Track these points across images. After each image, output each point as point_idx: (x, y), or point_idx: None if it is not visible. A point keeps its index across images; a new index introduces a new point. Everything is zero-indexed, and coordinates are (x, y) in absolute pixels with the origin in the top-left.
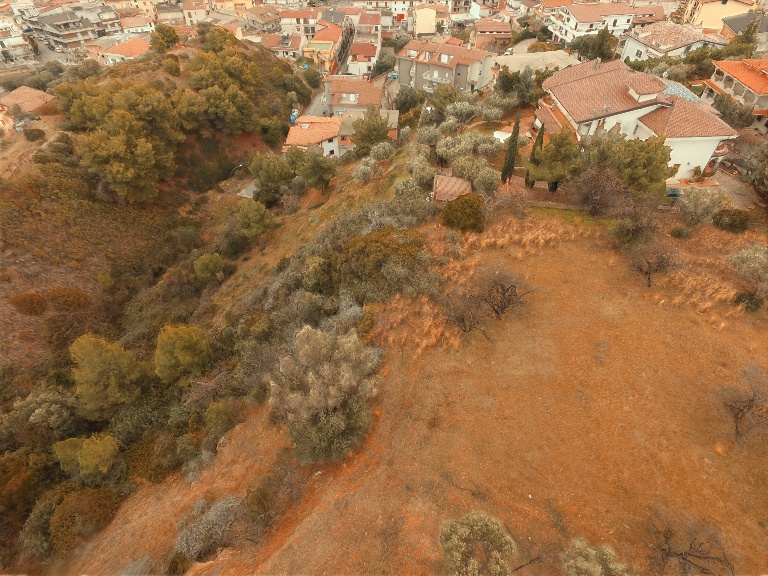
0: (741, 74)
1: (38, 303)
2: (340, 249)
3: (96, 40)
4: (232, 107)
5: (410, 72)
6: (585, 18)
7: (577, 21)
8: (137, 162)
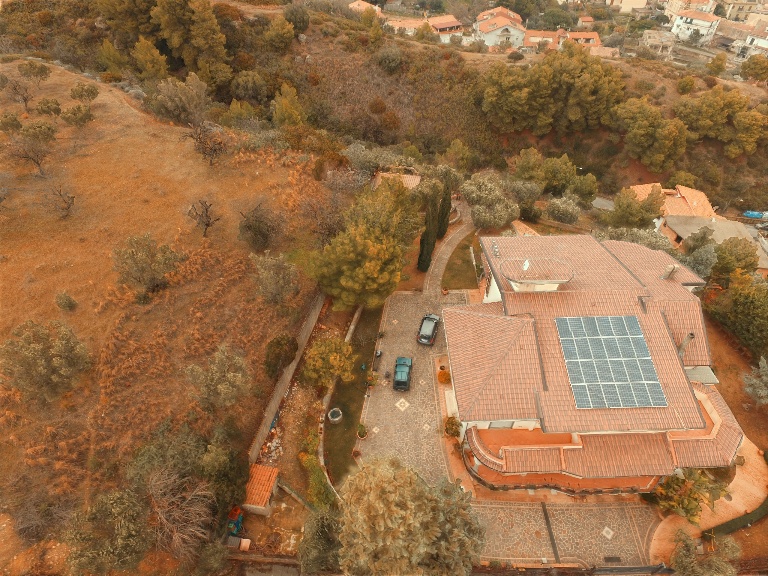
0: None
1: (378, 108)
2: None
3: None
4: (642, 130)
5: None
6: None
7: None
8: None
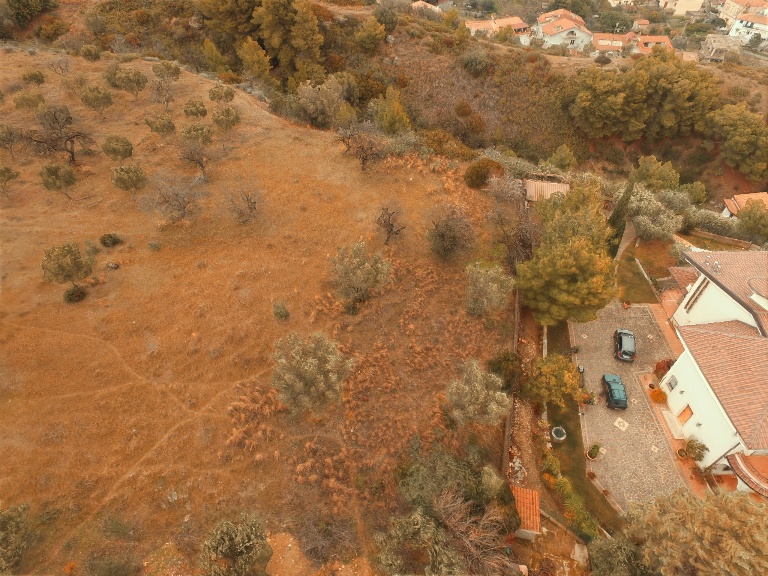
0: None
1: (464, 111)
2: None
3: None
4: (744, 138)
5: None
6: None
7: None
8: None
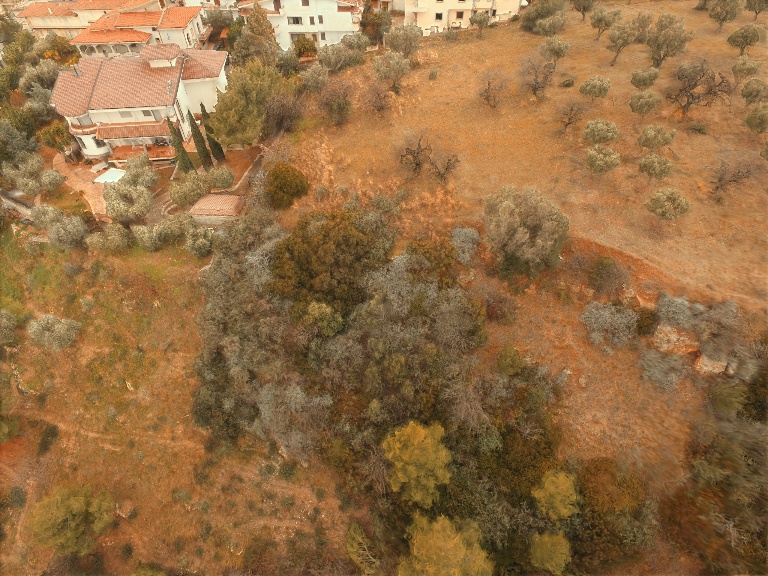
0: (108, 38)
1: None
2: (270, 313)
3: None
4: None
5: None
6: None
7: None
8: None
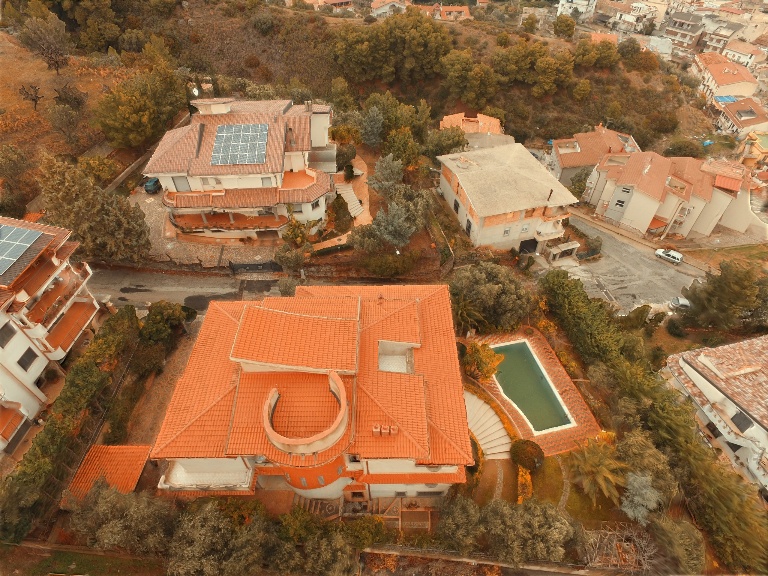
0: (373, 291)
1: (252, 63)
2: None
3: (644, 35)
4: (456, 73)
5: None
6: None
7: None
8: None
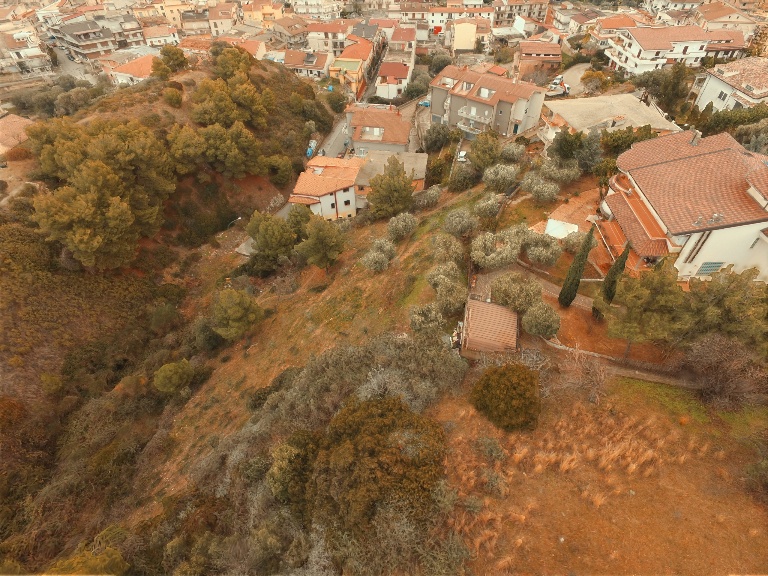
0: None
1: None
2: (328, 411)
3: (112, 54)
4: (234, 149)
5: (444, 105)
6: (651, 45)
7: (641, 48)
8: (108, 225)
